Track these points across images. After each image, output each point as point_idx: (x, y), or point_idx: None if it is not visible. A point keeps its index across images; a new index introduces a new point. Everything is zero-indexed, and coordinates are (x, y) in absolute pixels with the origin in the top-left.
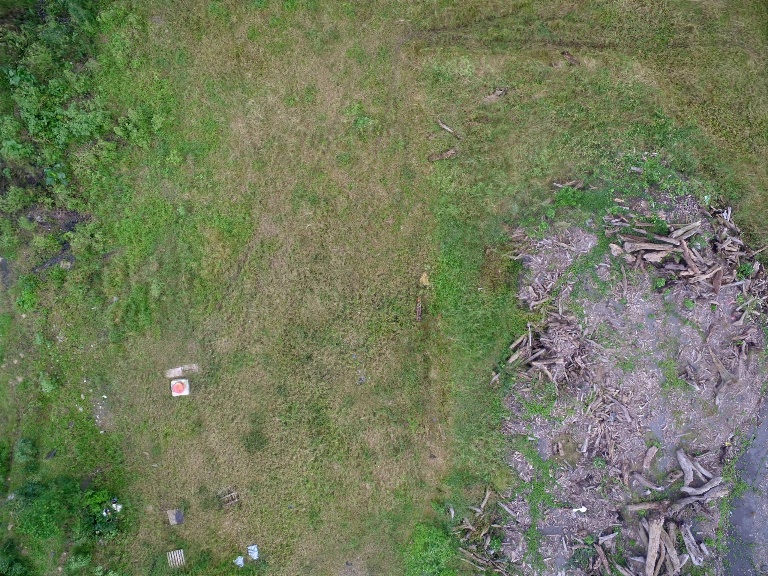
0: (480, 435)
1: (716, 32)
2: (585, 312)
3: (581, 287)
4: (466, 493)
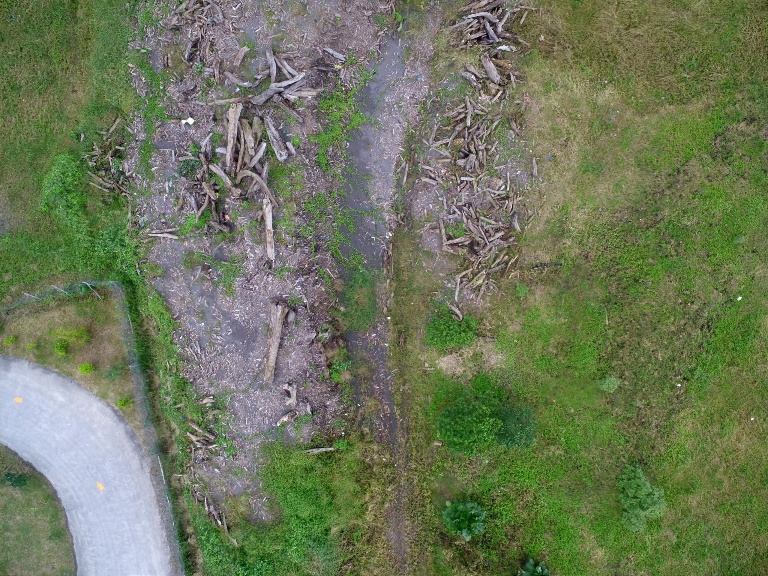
0: (110, 61)
1: None
2: None
3: None
4: (98, 121)
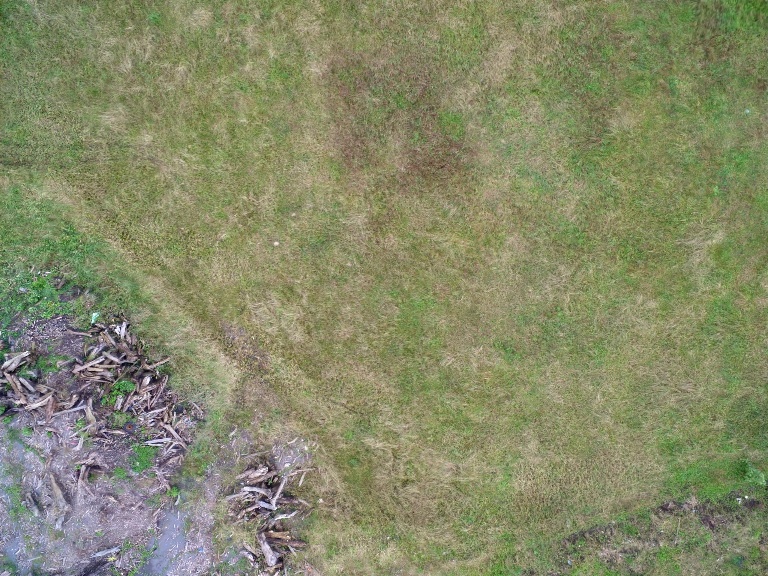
0: None
1: (128, 146)
2: None
3: None
4: None
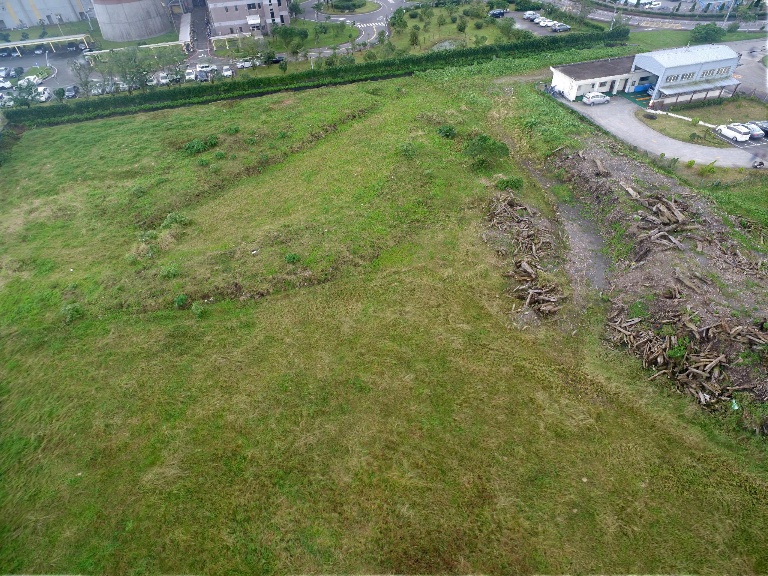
0: None
1: None
2: None
3: None
4: None
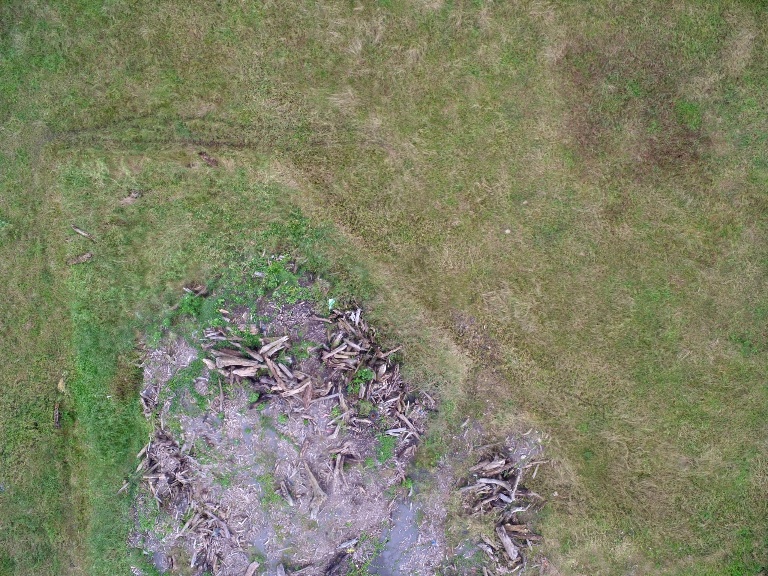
0: (110, 546)
1: (356, 130)
2: (182, 428)
3: (178, 402)
4: None
